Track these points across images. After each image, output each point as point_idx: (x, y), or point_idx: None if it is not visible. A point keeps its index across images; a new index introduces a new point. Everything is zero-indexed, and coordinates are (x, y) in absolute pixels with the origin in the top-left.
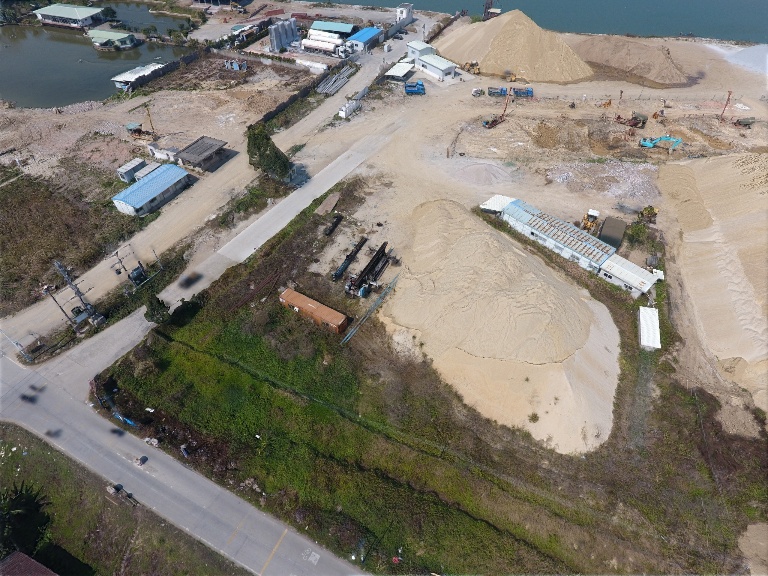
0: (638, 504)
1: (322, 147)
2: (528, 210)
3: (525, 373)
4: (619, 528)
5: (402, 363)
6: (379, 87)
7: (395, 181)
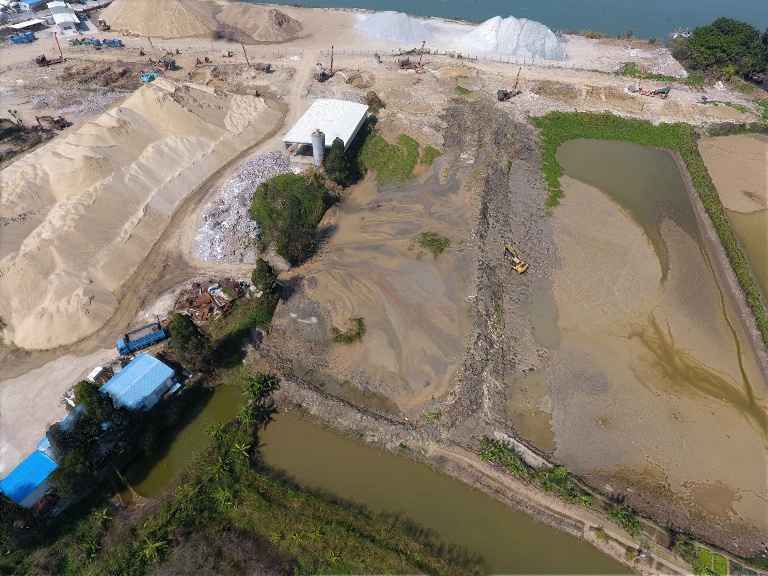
0: None
1: None
2: None
3: None
4: None
5: None
6: None
7: None
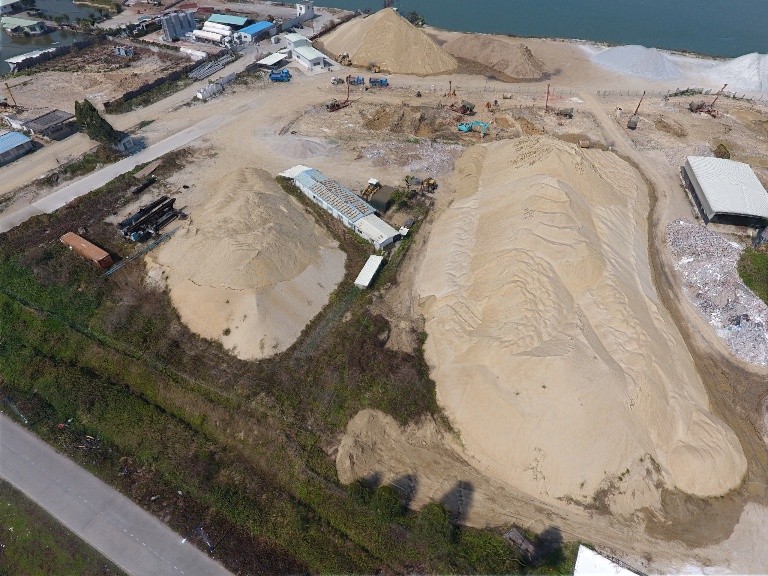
0: (281, 395)
1: (169, 123)
2: (315, 177)
3: (227, 297)
4: (254, 410)
5: (146, 292)
6: (248, 74)
7: (220, 153)
